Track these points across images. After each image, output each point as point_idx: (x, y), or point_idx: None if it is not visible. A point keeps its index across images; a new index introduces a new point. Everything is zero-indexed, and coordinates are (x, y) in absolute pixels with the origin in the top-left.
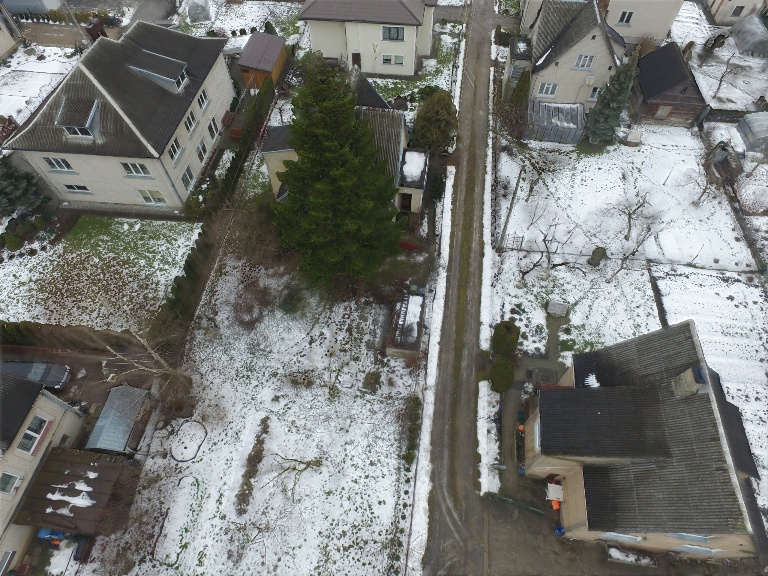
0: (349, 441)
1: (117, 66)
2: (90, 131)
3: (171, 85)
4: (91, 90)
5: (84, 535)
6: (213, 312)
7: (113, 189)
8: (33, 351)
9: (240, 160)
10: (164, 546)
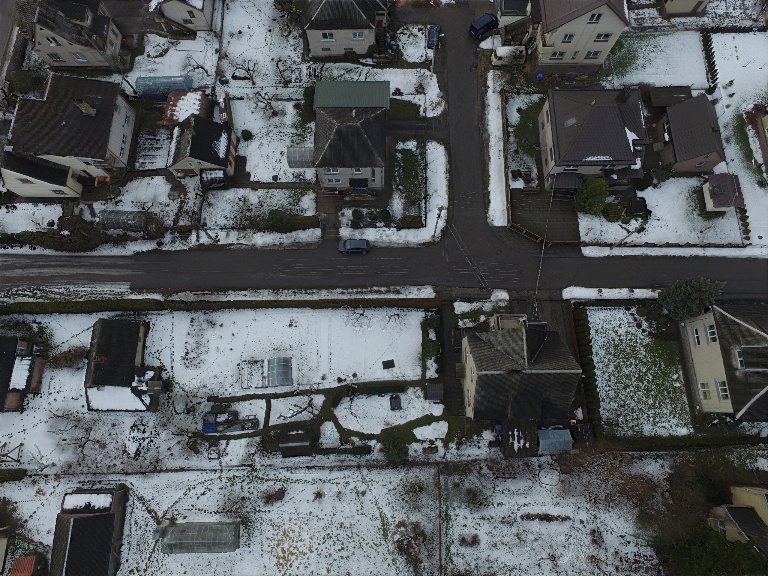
0: (568, 573)
1: None
2: None
3: None
4: None
5: (500, 443)
6: (627, 463)
7: (704, 364)
8: None
9: (763, 442)
10: (501, 482)
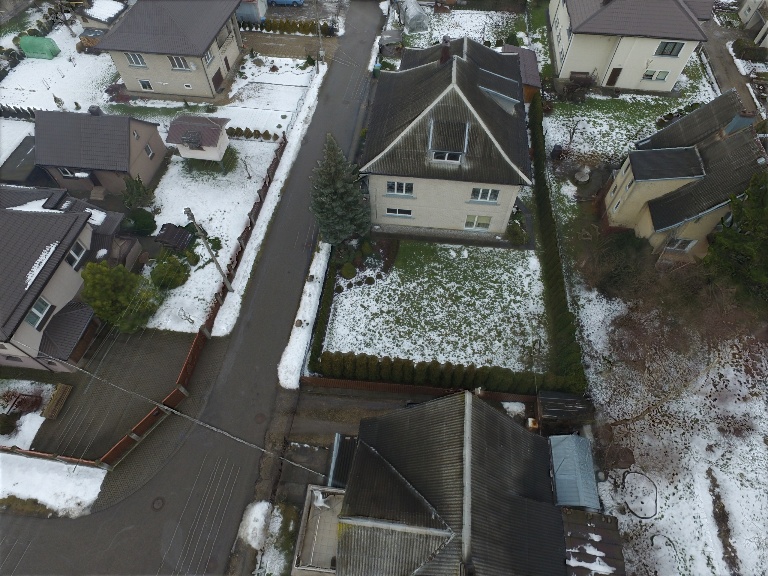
0: None
1: (474, 87)
2: (461, 156)
3: (510, 106)
4: (463, 113)
5: None
6: (592, 349)
7: (441, 214)
8: (423, 390)
9: None
10: None
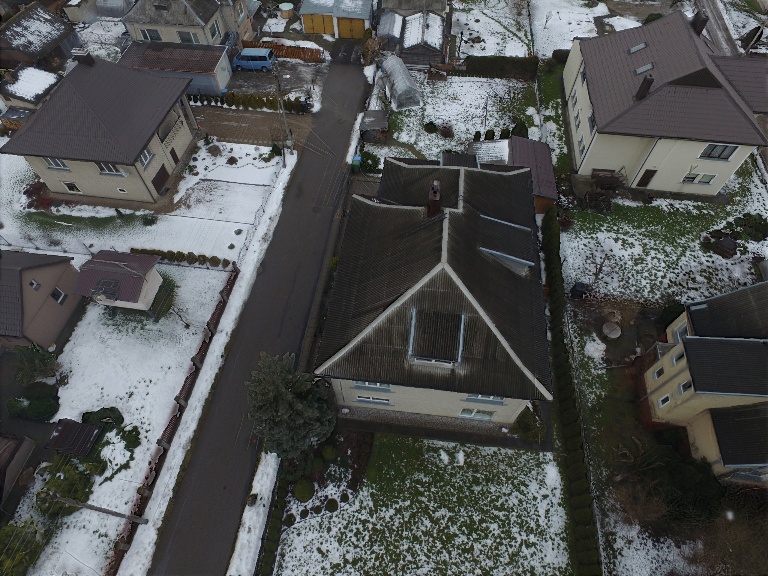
0: None
1: (472, 253)
2: None
3: (521, 266)
4: (457, 301)
5: None
6: None
7: (428, 404)
8: None
9: None
10: None
